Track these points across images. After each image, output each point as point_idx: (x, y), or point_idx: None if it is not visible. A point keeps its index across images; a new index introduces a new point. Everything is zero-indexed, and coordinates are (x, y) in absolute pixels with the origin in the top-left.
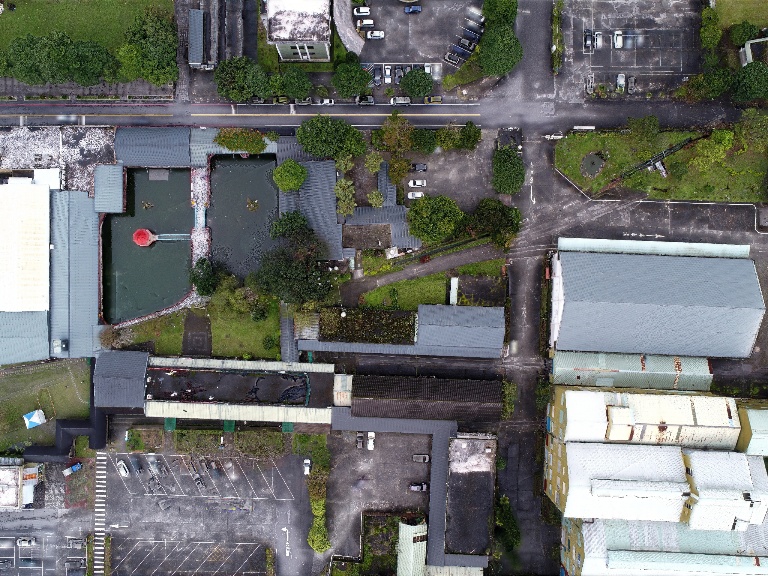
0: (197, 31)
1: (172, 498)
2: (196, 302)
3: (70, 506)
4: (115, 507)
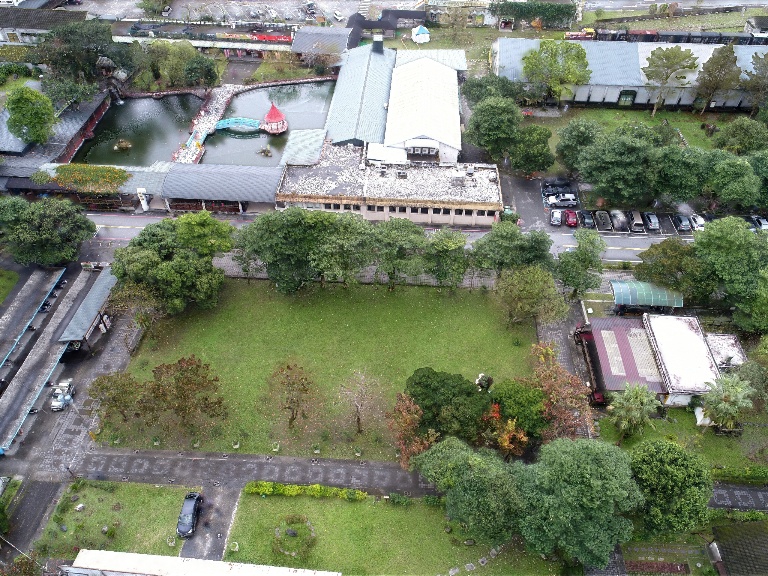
0: (88, 309)
1: (298, 7)
2: (232, 88)
3: (392, 7)
4: (351, 6)
